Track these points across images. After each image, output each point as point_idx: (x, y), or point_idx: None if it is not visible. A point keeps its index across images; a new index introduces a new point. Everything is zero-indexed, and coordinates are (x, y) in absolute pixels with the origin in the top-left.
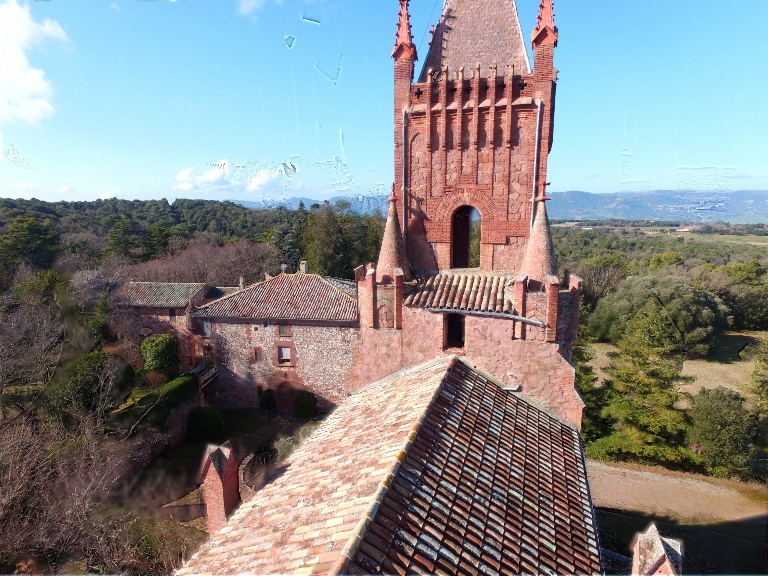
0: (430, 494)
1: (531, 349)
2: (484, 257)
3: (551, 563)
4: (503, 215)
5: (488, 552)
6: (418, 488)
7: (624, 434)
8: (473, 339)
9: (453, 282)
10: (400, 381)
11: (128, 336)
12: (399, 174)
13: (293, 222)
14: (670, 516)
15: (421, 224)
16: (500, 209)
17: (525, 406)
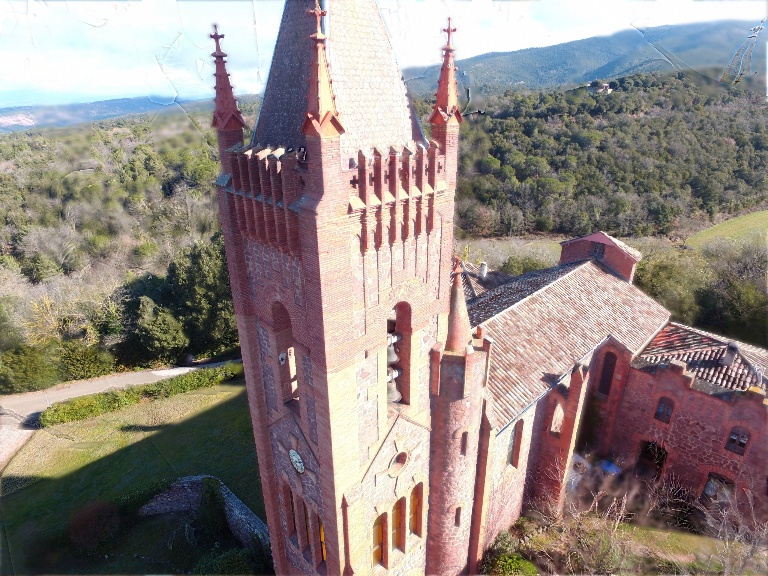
0: None
1: None
2: None
3: None
4: None
5: None
6: None
7: None
8: None
9: None
10: None
11: None
12: None
13: None
14: None
15: None
16: None
17: None
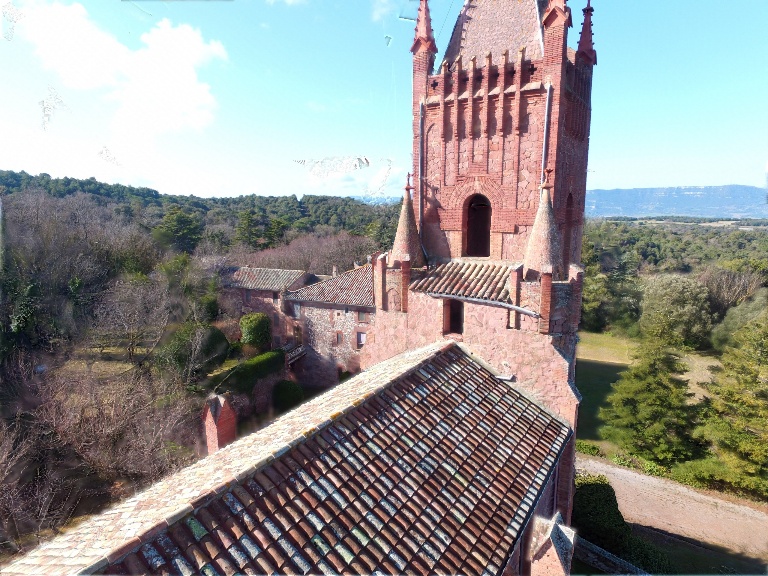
0: (350, 450)
1: (525, 339)
2: (493, 246)
3: (451, 531)
4: (512, 203)
5: (384, 507)
6: (341, 444)
7: (721, 460)
8: (470, 326)
9: (461, 270)
10: (402, 361)
11: (230, 312)
12: (416, 164)
13: (391, 216)
14: (763, 559)
15: (436, 212)
16: (509, 197)
17: (515, 396)
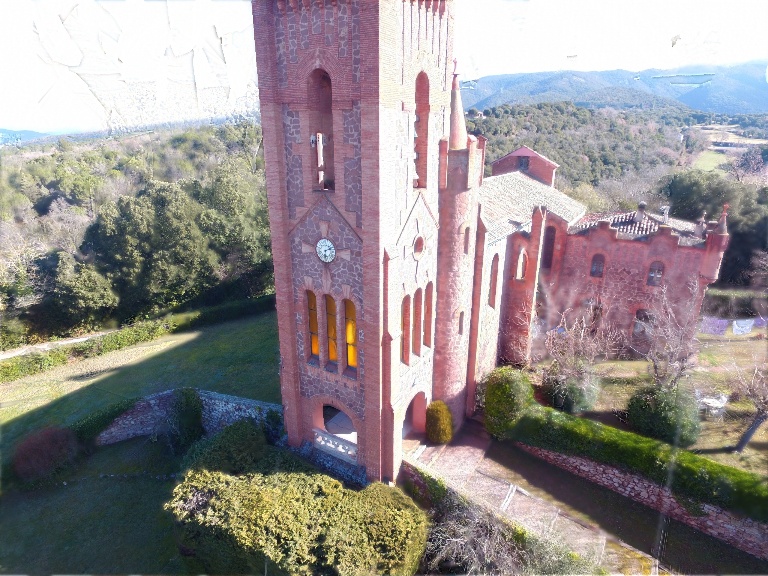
0: None
1: None
2: None
3: None
4: None
5: None
6: None
7: None
8: None
9: None
10: None
11: None
12: None
13: None
14: None
15: None
16: None
17: None
